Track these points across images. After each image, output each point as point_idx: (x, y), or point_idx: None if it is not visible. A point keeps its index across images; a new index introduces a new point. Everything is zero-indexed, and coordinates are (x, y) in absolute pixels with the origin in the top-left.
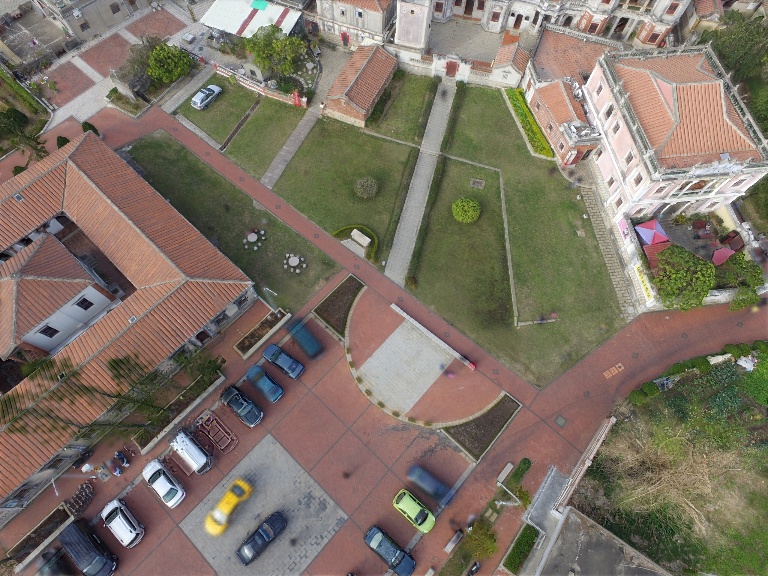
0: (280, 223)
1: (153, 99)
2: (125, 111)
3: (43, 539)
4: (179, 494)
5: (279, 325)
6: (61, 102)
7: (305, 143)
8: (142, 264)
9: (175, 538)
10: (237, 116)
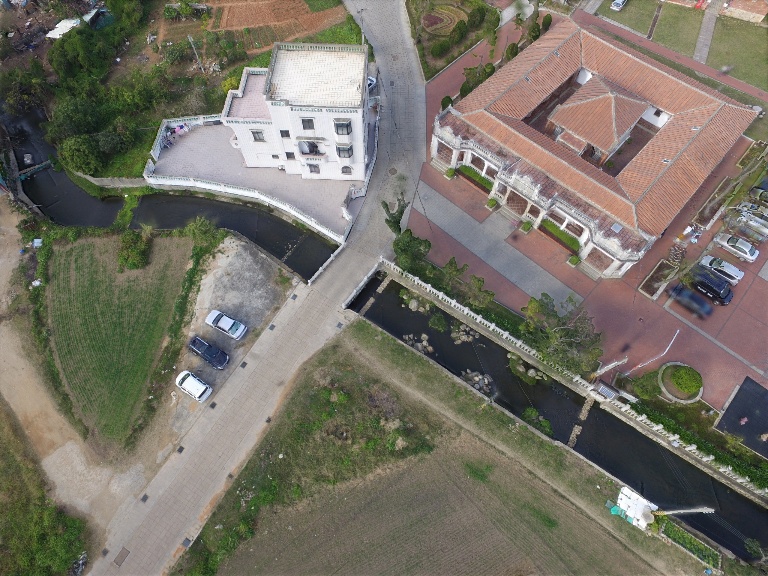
0: (725, 86)
1: (575, 4)
2: (558, 12)
3: (662, 280)
4: (757, 251)
5: (767, 150)
6: (502, 7)
7: (715, 33)
8: (673, 97)
9: (760, 283)
10: (648, 16)
